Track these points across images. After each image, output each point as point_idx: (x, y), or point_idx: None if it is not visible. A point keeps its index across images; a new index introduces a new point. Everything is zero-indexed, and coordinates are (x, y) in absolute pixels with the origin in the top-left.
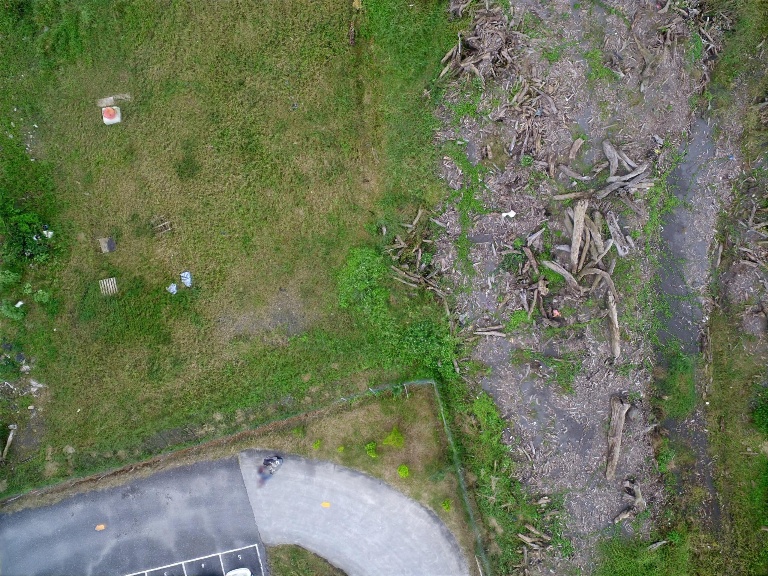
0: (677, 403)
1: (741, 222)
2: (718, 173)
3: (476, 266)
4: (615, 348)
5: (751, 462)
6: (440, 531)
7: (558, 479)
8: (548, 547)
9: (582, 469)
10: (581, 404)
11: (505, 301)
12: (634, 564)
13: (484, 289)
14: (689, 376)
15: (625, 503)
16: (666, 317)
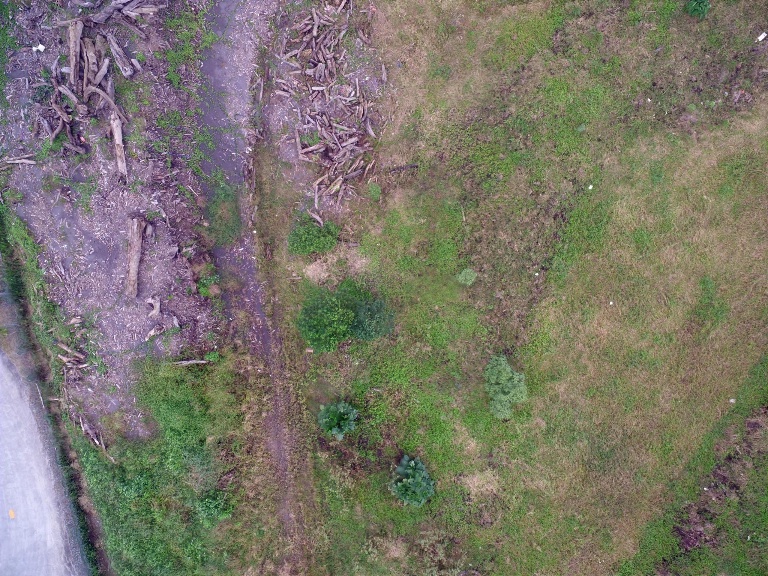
0: (220, 230)
1: (276, 55)
2: (256, 10)
3: (9, 99)
4: (118, 164)
5: (296, 287)
6: (2, 361)
7: (88, 299)
8: (82, 365)
9: (110, 288)
10: (103, 224)
11: (35, 130)
12: (164, 379)
13: (18, 121)
14: (232, 204)
15: (156, 321)
16: (210, 149)
